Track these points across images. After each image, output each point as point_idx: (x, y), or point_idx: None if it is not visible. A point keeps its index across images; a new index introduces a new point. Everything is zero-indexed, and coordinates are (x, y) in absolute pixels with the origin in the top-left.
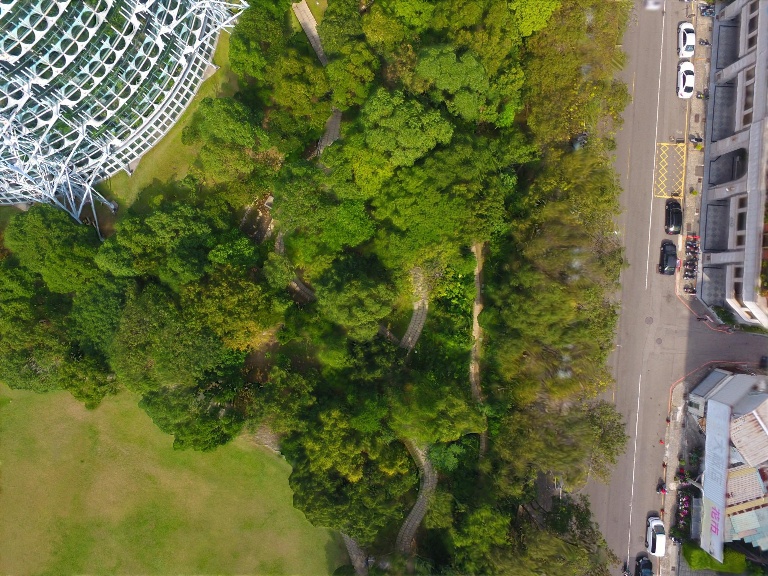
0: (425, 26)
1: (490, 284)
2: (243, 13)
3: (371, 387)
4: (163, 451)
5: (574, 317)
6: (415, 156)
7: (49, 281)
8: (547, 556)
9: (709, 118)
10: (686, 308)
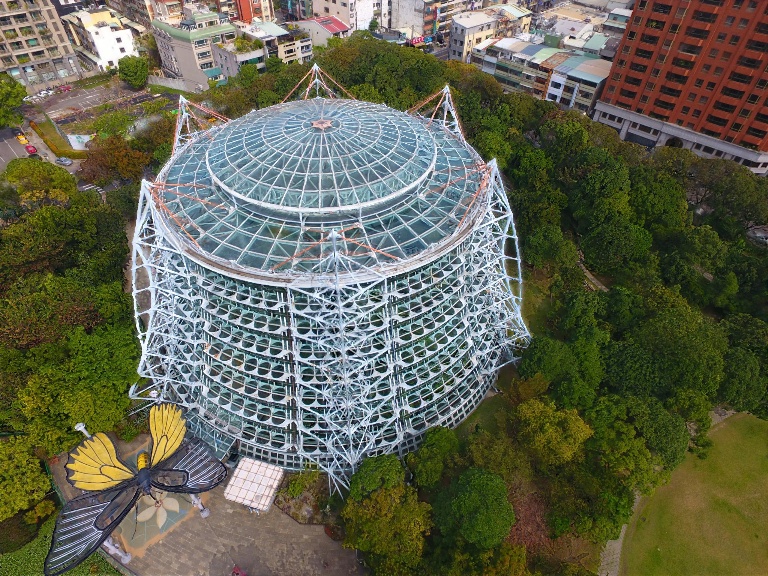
0: (553, 165)
1: (703, 220)
2: None
3: (760, 284)
4: (764, 467)
5: None
6: (630, 181)
7: (592, 372)
8: None
9: None
10: None
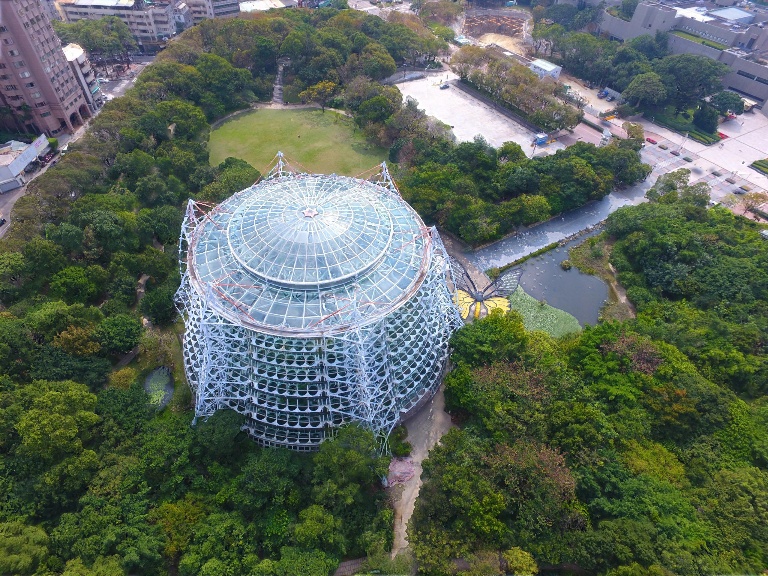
0: None
1: None
2: None
3: None
4: None
5: None
6: None
7: None
8: (109, 123)
9: None
10: (1, 211)
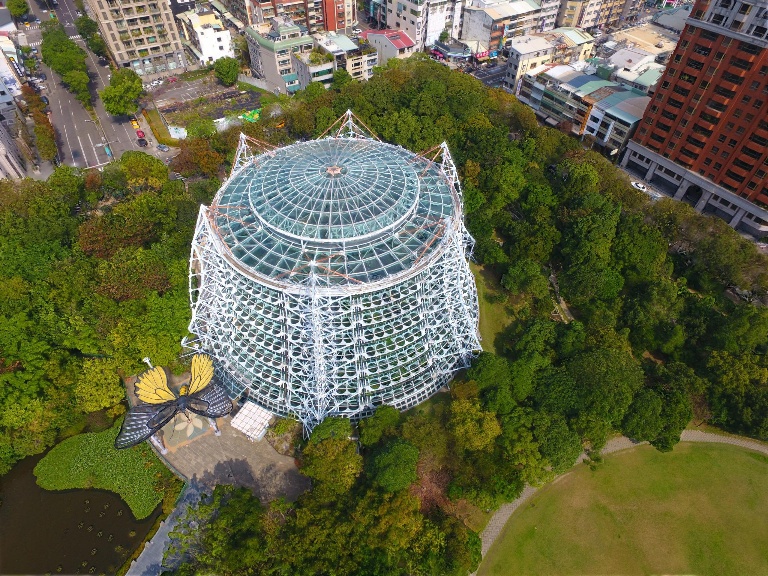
0: (558, 203)
1: (685, 272)
2: (477, 244)
3: (707, 339)
4: (652, 489)
5: (737, 244)
6: None
7: (520, 387)
8: None
9: (661, 192)
10: None
